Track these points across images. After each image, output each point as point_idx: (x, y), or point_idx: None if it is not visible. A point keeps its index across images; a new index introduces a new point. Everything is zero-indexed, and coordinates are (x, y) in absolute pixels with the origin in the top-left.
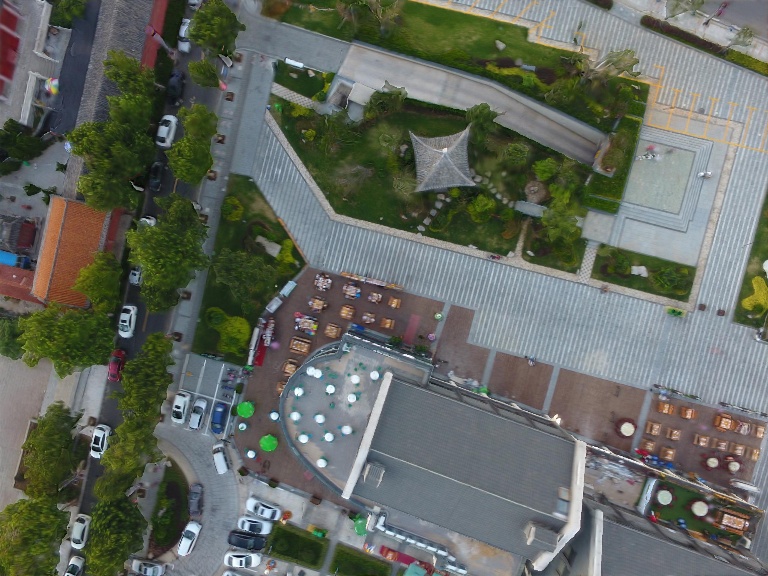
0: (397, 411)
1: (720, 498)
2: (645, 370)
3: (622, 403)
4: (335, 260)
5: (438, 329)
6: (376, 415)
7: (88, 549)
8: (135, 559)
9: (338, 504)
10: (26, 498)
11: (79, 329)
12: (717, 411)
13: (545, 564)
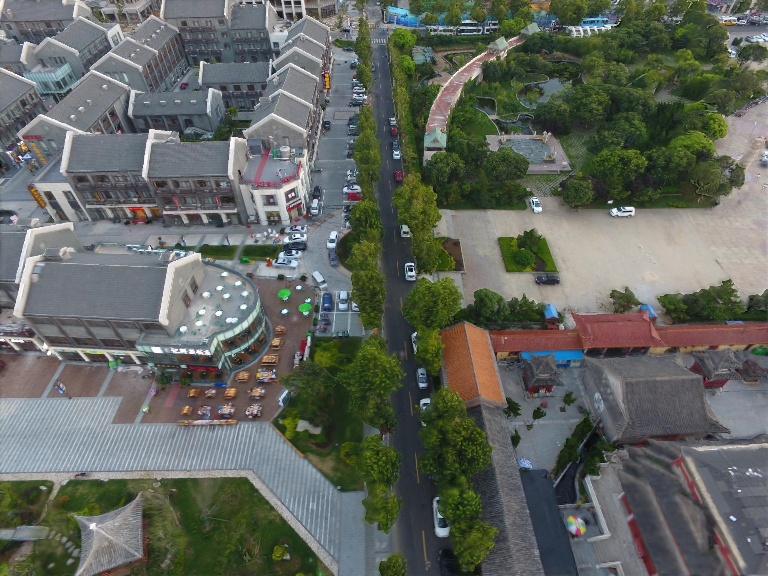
0: (154, 298)
1: None
2: None
3: None
4: (245, 434)
5: (149, 401)
6: (166, 288)
7: (376, 210)
8: None
9: None
10: (448, 236)
11: (420, 305)
12: None
13: None
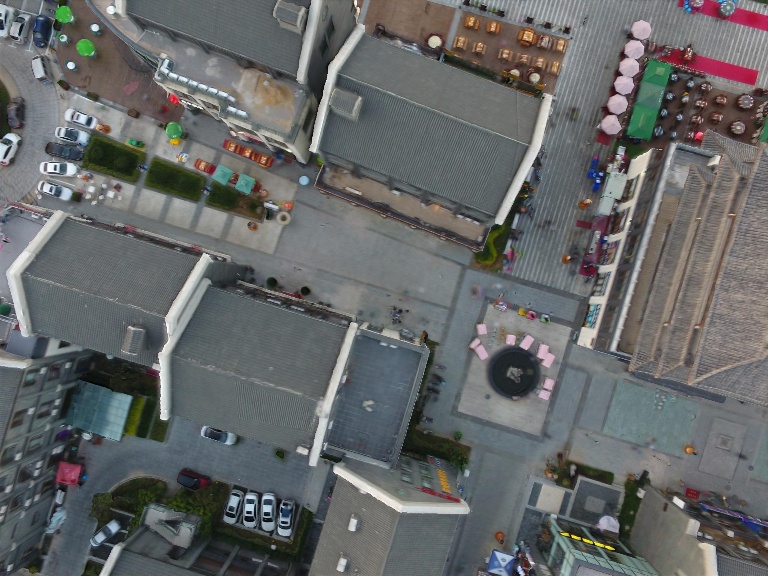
0: None
1: (503, 72)
2: None
3: (432, 21)
4: None
5: None
6: None
7: None
8: None
9: (155, 118)
10: None
11: None
12: (522, 28)
13: (303, 66)
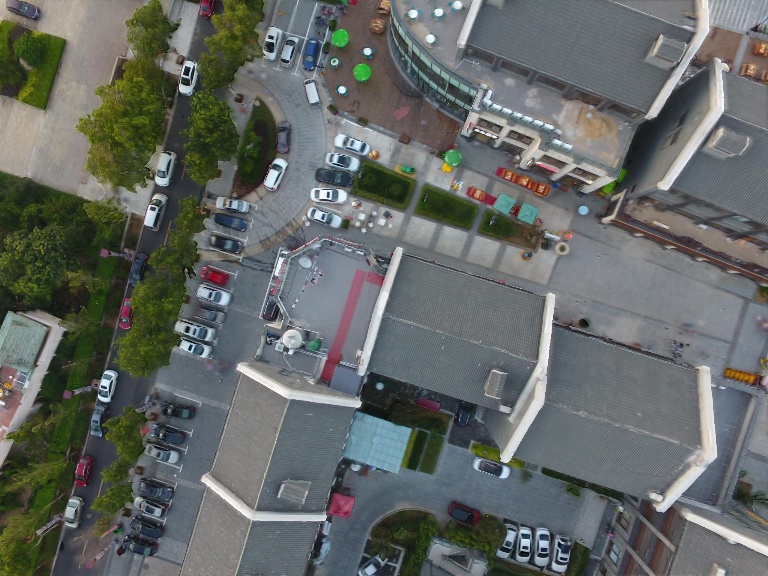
0: None
1: None
2: (742, 14)
3: (717, 47)
4: None
5: None
6: None
7: None
8: (219, 196)
9: (427, 144)
10: None
11: None
12: None
13: (662, 102)
